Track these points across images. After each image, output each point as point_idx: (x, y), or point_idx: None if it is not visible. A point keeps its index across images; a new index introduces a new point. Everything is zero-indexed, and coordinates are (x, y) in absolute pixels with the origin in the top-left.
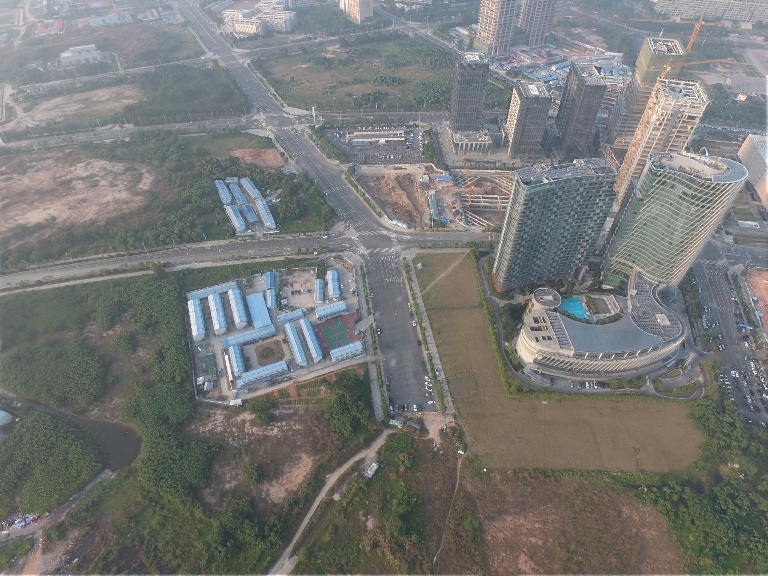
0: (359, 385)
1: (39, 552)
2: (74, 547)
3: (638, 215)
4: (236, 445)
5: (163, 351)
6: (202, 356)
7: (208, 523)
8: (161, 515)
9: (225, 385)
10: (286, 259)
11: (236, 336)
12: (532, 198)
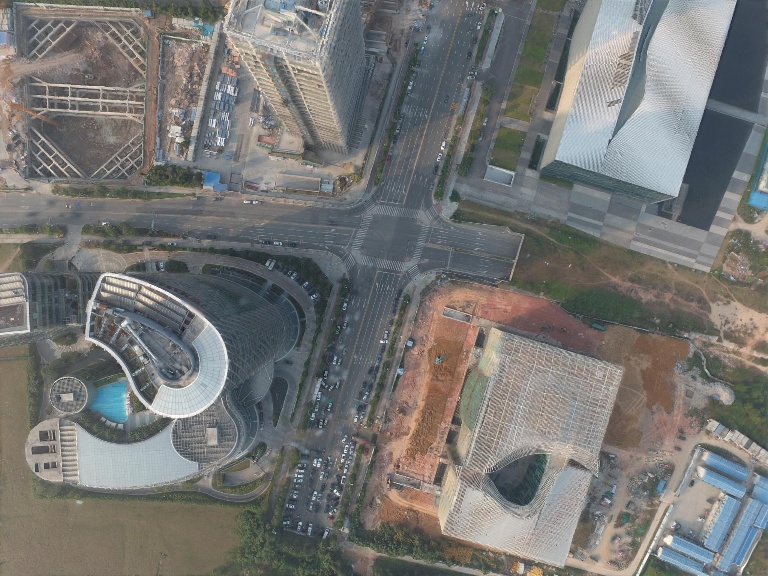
0: None
1: None
2: None
3: None
4: None
5: None
6: None
7: None
8: None
9: None
10: None
11: None
12: None
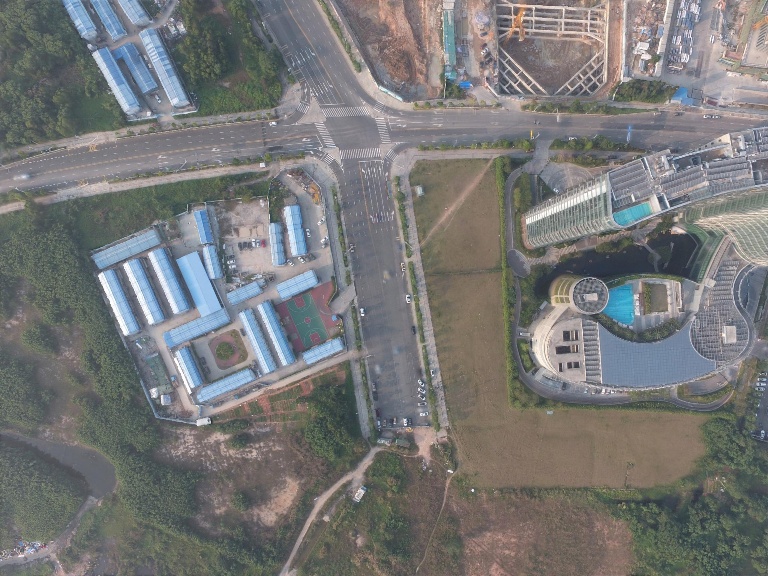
0: (341, 400)
1: (62, 572)
2: (92, 568)
3: None
4: (216, 470)
5: (94, 357)
6: (145, 359)
7: (208, 547)
8: (161, 542)
9: (185, 397)
10: (219, 183)
11: (180, 330)
12: None
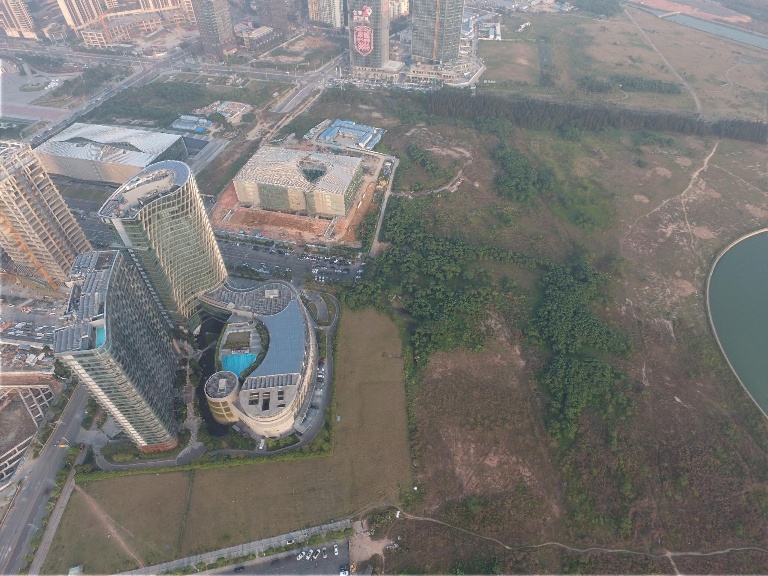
0: None
1: None
2: None
3: (159, 262)
4: None
5: None
6: None
7: None
8: None
9: None
10: None
11: None
12: (115, 348)
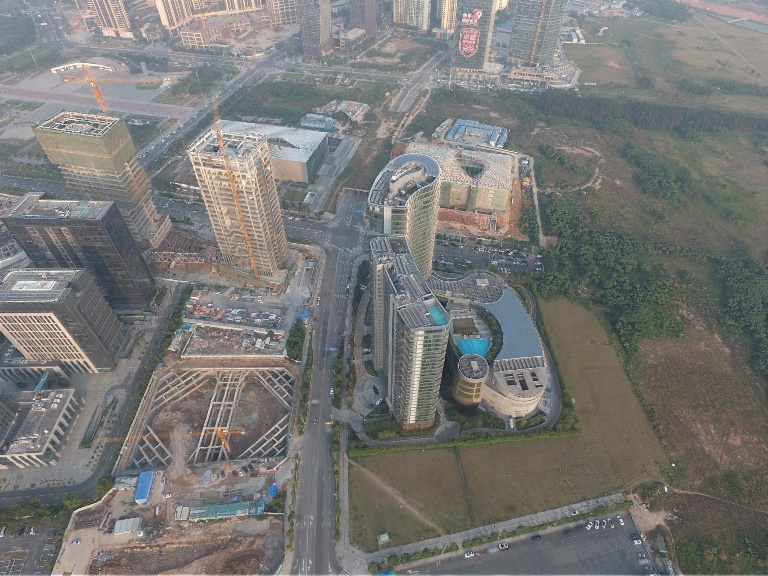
0: None
1: None
2: None
3: None
4: None
5: None
6: None
7: None
8: None
9: None
10: None
11: None
12: None
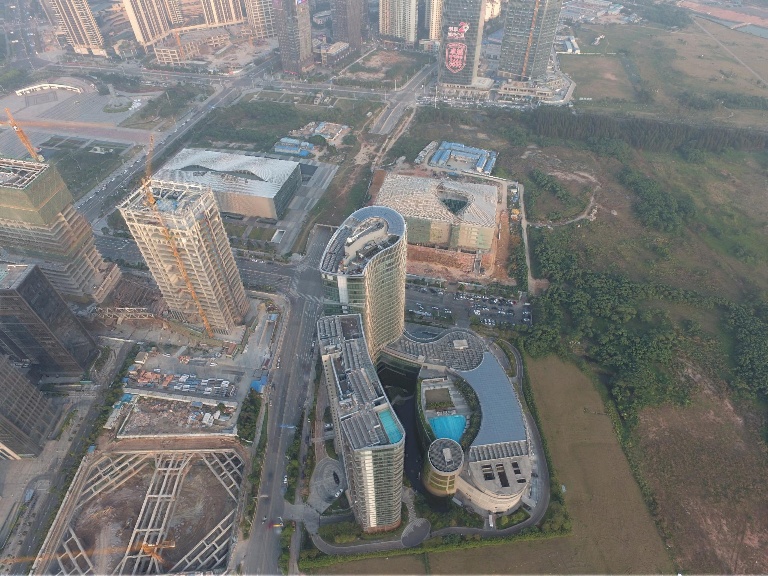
0: None
1: None
2: None
3: (367, 317)
4: None
5: None
6: None
7: None
8: None
9: None
10: None
11: None
12: None
